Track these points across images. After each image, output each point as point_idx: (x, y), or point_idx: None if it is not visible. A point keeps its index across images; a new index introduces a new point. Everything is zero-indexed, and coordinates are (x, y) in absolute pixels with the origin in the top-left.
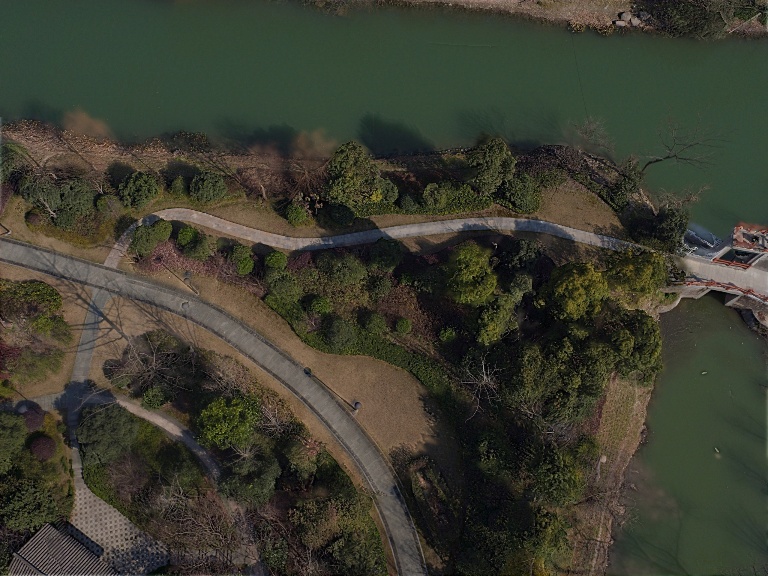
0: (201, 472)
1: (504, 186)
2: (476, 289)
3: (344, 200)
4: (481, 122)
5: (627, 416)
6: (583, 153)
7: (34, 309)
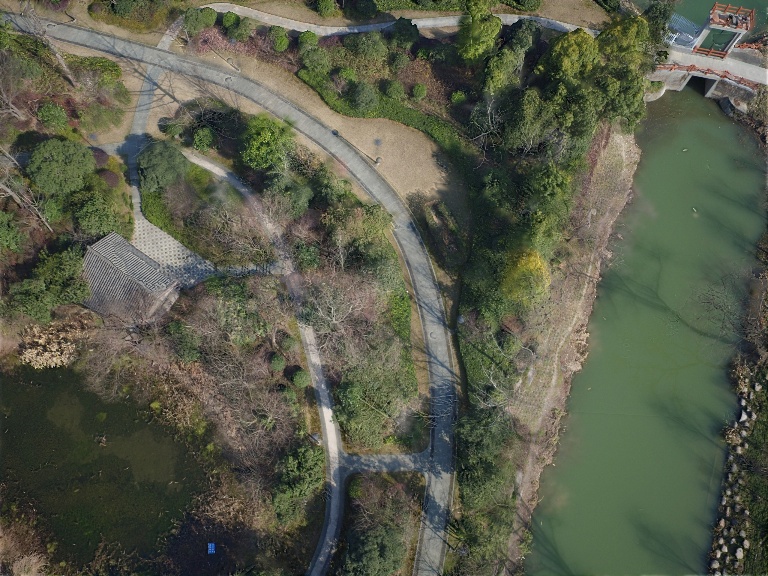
0: (244, 204)
1: None
2: (483, 24)
3: None
4: None
5: (615, 180)
6: None
7: (98, 76)
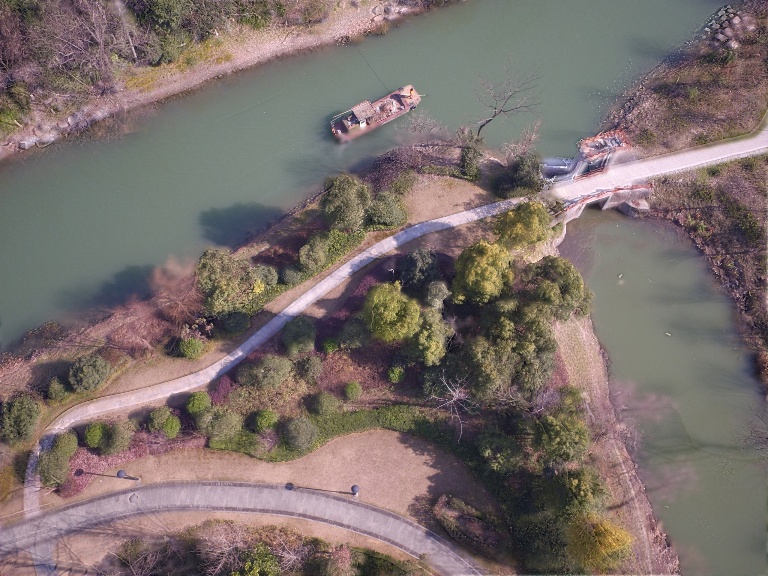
0: None
1: (367, 213)
2: (405, 323)
3: (231, 308)
4: (310, 166)
5: (584, 350)
6: None
7: None
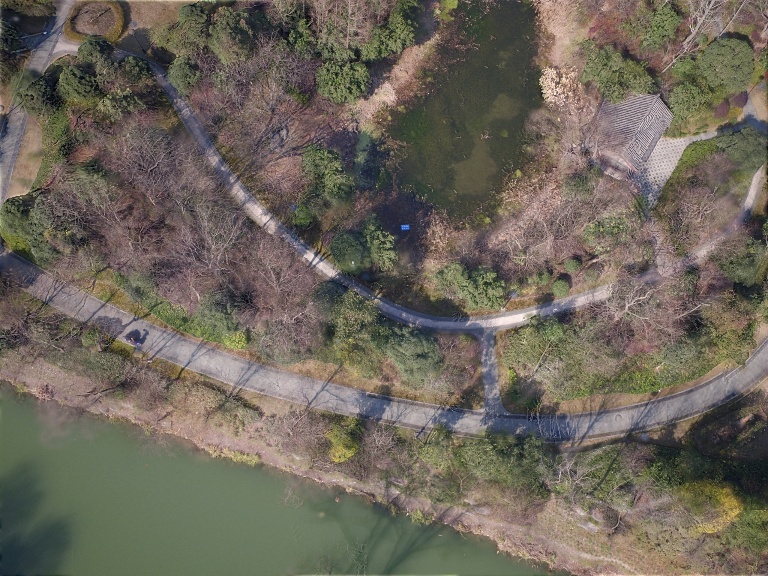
0: (721, 227)
1: None
2: None
3: None
4: None
5: None
6: None
7: None
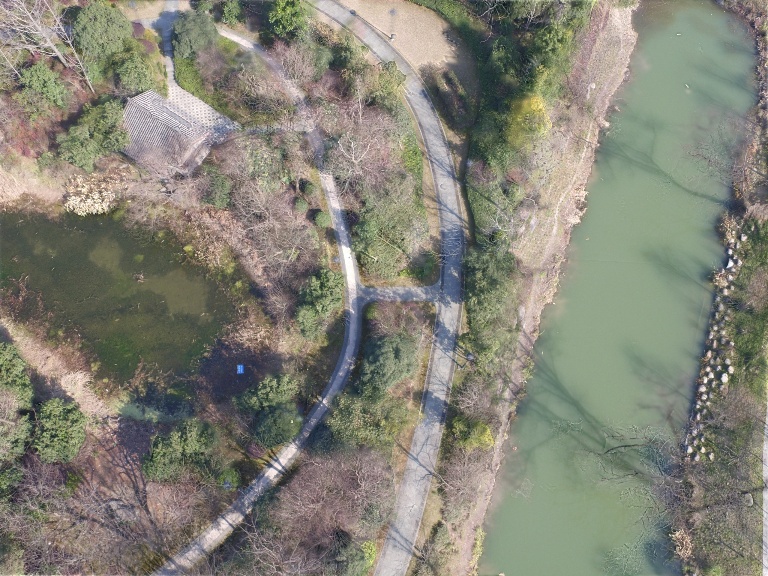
0: (269, 71)
1: None
2: None
3: None
4: None
5: (613, 59)
6: None
7: None
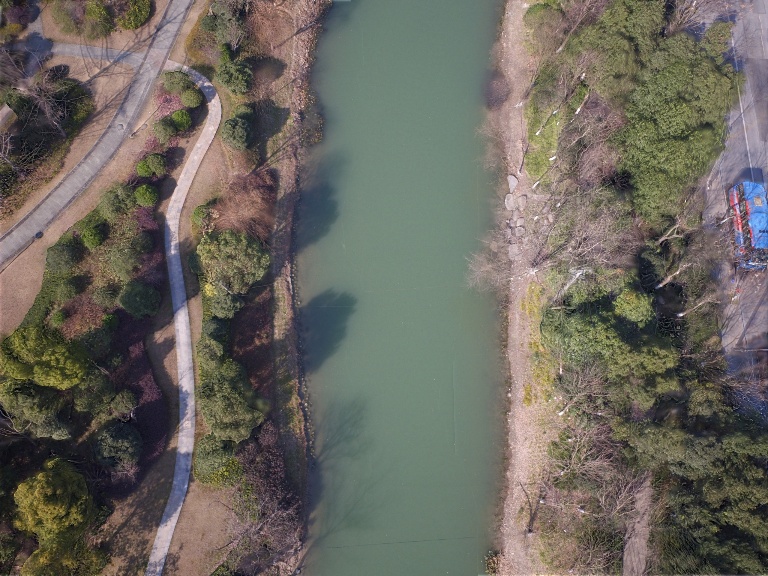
0: None
1: None
2: (2, 350)
3: (198, 252)
4: (345, 429)
5: None
6: (303, 559)
7: (121, 8)
